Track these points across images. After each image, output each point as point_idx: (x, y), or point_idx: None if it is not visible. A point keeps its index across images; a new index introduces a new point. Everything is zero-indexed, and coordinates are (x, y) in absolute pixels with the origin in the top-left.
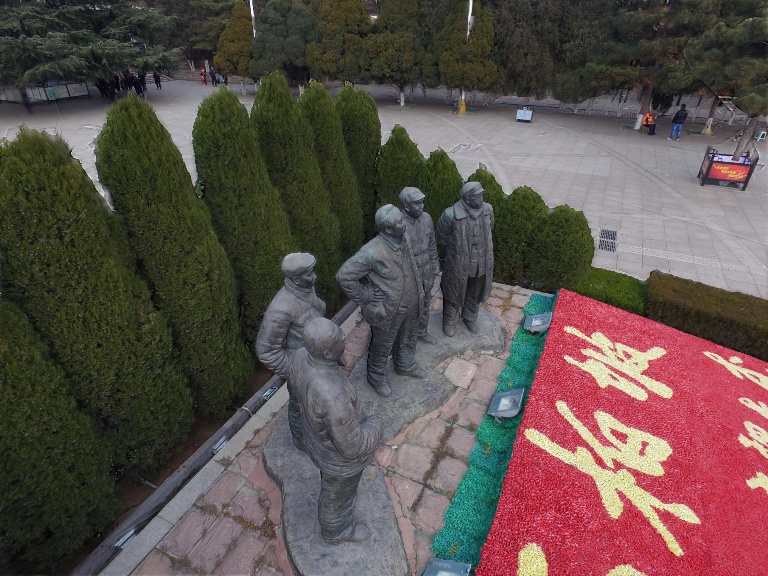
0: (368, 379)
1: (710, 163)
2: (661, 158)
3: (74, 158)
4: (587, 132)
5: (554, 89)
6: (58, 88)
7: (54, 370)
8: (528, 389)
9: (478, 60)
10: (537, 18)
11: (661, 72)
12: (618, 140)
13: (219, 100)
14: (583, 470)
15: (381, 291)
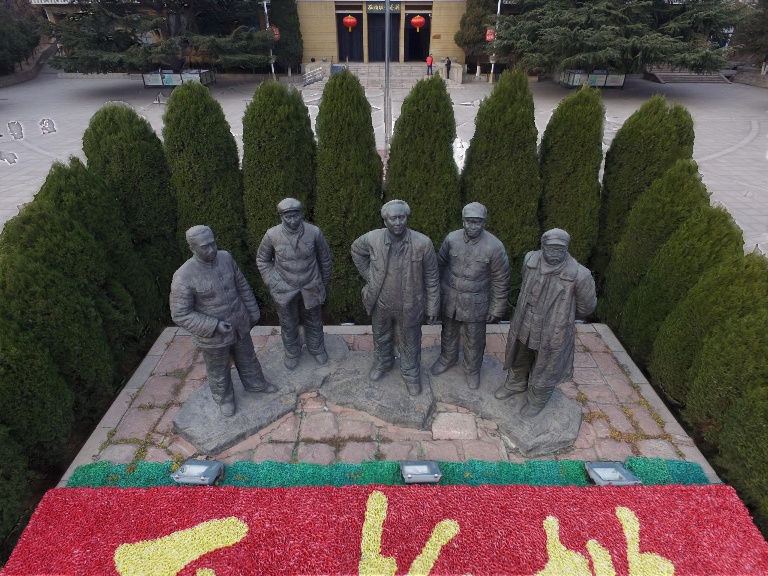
0: None
1: None
2: None
3: (299, 104)
4: None
5: None
6: (586, 76)
7: (236, 219)
8: None
9: None
10: None
11: None
12: None
13: (421, 84)
14: (361, 569)
15: None
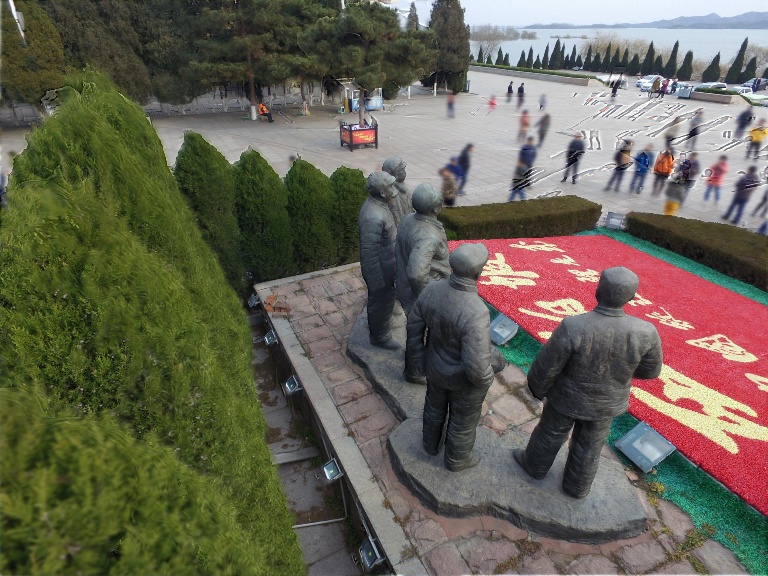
0: (414, 380)
1: (350, 132)
2: (301, 138)
3: None
4: (218, 129)
5: (157, 92)
6: None
7: None
8: (496, 314)
9: (53, 66)
10: (104, 16)
11: (259, 66)
12: (253, 131)
13: (113, 108)
14: None
15: (439, 275)
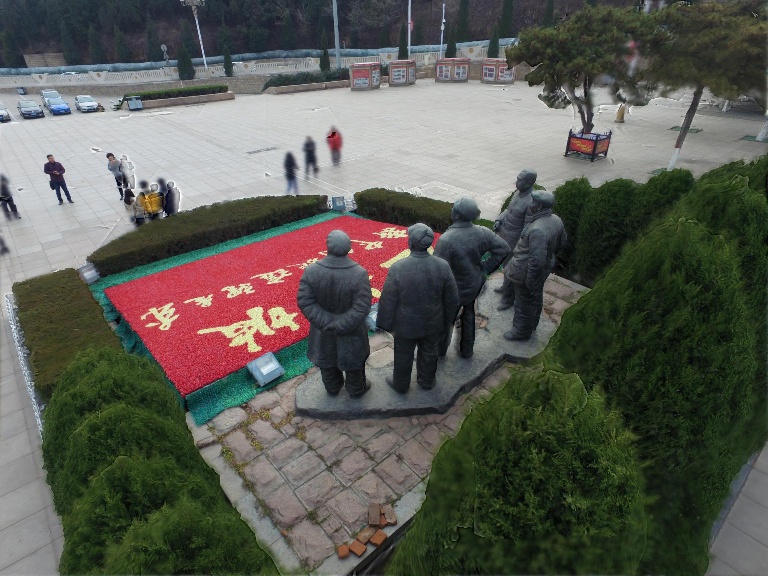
0: None
1: None
2: None
3: None
4: None
5: None
6: None
7: None
8: None
9: None
10: None
11: None
12: None
13: None
14: None
15: None
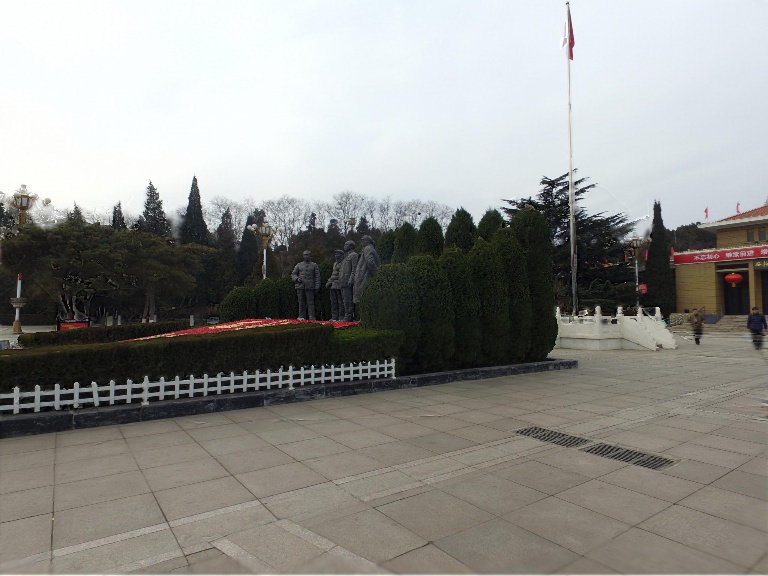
0: None
1: None
2: None
3: None
4: None
5: None
6: None
7: None
8: None
9: None
10: None
11: None
12: None
13: None
14: None
15: None
